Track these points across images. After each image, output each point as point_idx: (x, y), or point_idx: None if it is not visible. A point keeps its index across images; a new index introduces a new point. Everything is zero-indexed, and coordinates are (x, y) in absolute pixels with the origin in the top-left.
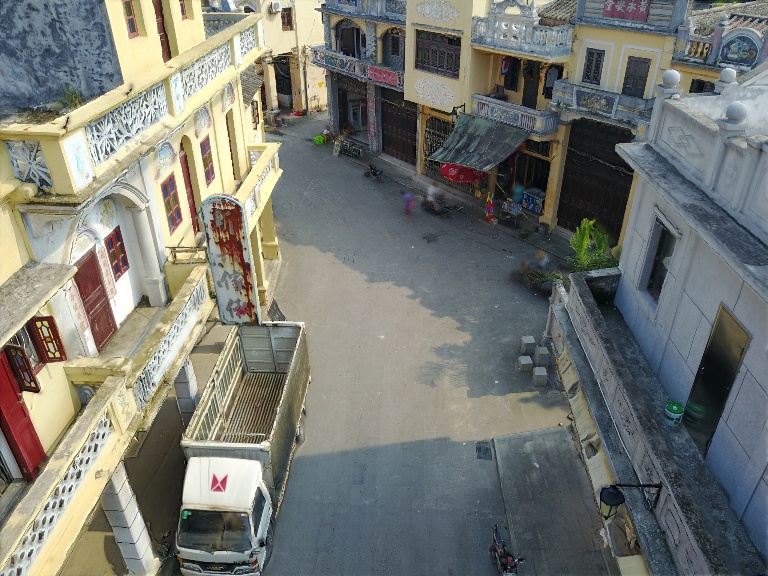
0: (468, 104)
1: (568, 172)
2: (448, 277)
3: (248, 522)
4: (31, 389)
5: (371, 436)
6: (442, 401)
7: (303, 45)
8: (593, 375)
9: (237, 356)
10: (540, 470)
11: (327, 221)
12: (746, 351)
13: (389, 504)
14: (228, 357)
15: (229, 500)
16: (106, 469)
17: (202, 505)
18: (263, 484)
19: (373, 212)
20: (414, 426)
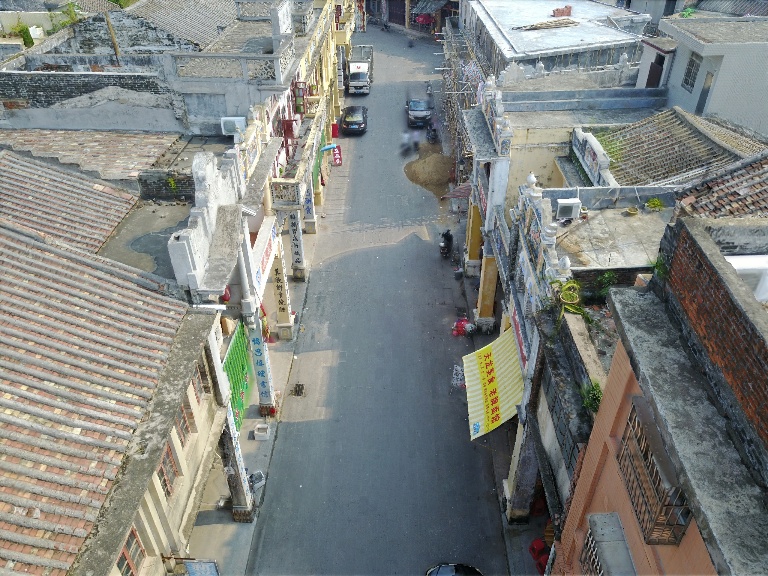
0: None
1: None
2: (418, 55)
3: None
4: None
5: None
6: None
7: None
8: None
9: None
10: None
11: (368, 43)
12: (466, 10)
13: (399, 88)
14: None
15: (362, 70)
16: (350, 34)
17: (355, 72)
18: (368, 72)
19: (387, 40)
20: (406, 79)
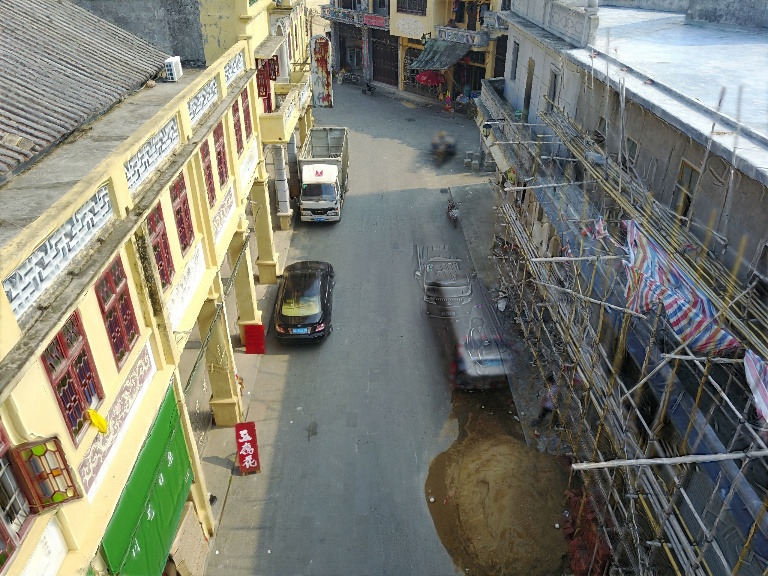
0: (433, 32)
1: (497, 73)
2: (423, 135)
3: (334, 188)
4: (273, 79)
5: (384, 188)
6: (421, 177)
7: (310, 8)
8: (488, 112)
9: (310, 148)
10: (473, 194)
11: (341, 114)
12: (534, 68)
13: (396, 206)
14: (308, 143)
15: (325, 179)
16: (296, 116)
17: (312, 182)
18: None
19: (371, 110)
20: (407, 185)
